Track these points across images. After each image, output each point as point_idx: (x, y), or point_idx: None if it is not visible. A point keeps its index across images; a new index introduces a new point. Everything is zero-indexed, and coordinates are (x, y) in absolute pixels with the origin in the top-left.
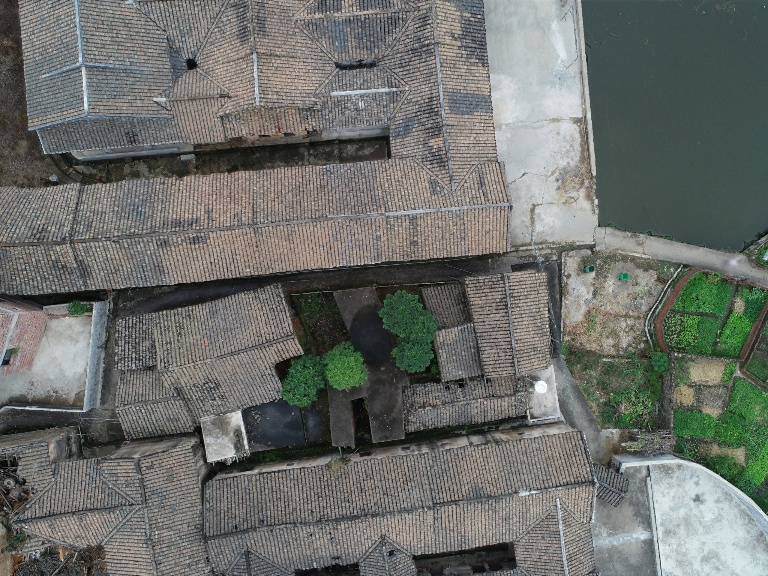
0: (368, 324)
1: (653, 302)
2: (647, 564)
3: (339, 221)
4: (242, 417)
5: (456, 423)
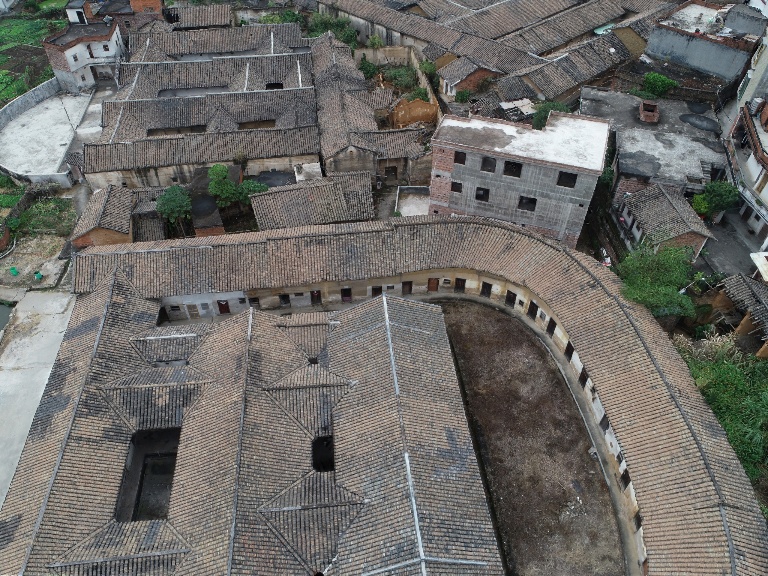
0: (203, 212)
1: (1, 261)
2: (74, 149)
3: None
4: None
5: None
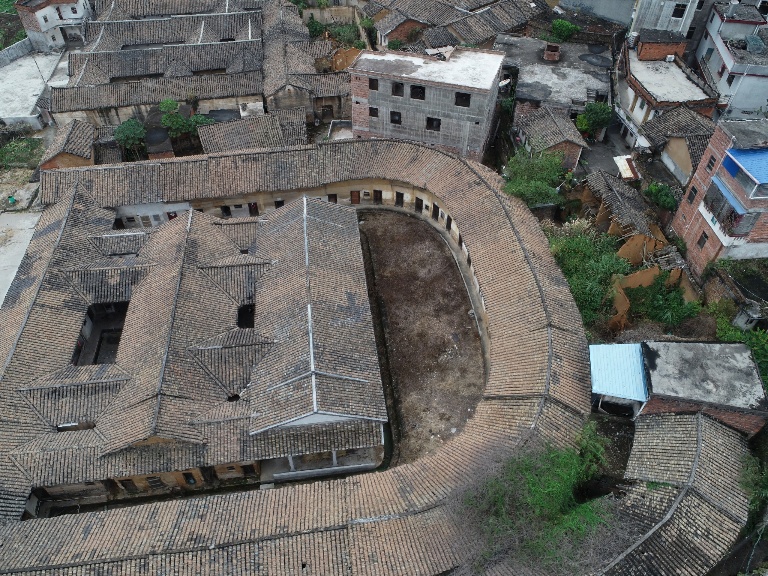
0: (156, 140)
1: None
2: None
3: None
4: None
5: None
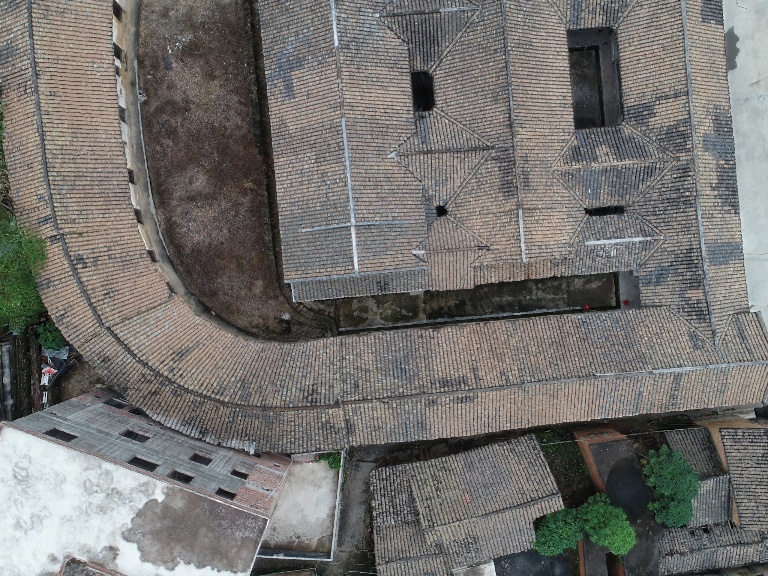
0: (625, 476)
1: None
2: None
3: (606, 379)
4: (494, 568)
5: (700, 568)
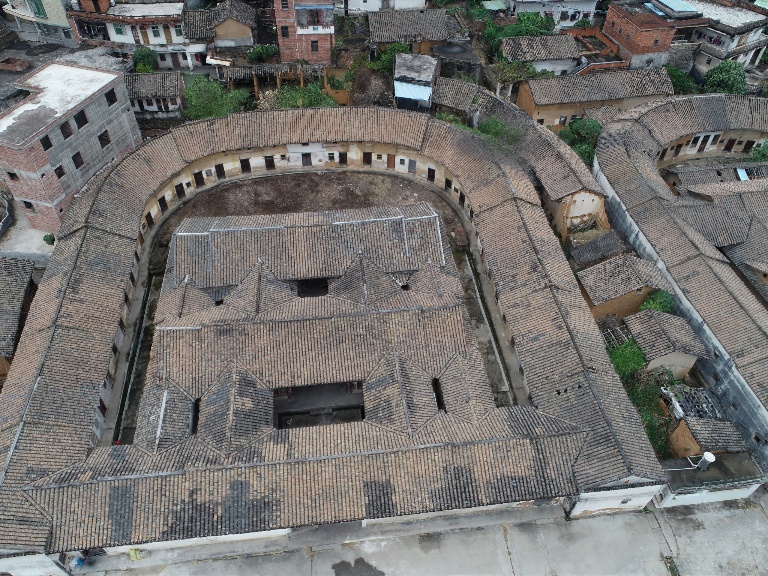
0: None
1: None
2: None
3: None
4: None
5: None
